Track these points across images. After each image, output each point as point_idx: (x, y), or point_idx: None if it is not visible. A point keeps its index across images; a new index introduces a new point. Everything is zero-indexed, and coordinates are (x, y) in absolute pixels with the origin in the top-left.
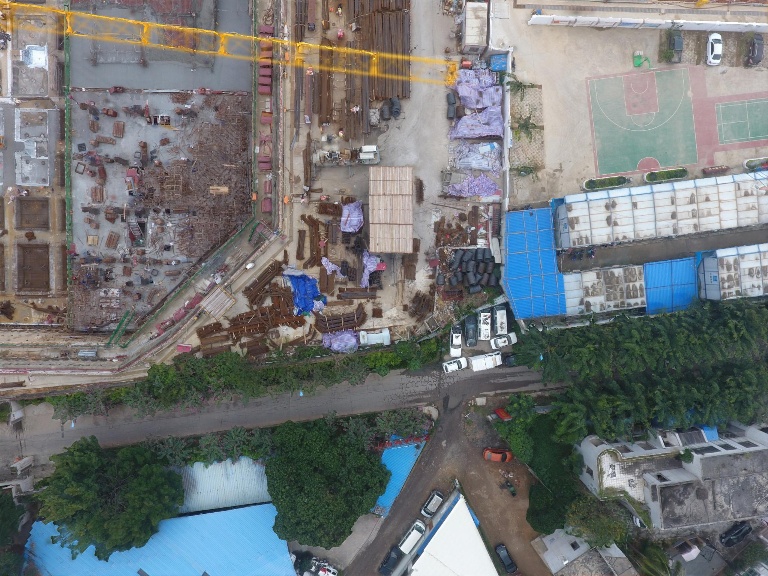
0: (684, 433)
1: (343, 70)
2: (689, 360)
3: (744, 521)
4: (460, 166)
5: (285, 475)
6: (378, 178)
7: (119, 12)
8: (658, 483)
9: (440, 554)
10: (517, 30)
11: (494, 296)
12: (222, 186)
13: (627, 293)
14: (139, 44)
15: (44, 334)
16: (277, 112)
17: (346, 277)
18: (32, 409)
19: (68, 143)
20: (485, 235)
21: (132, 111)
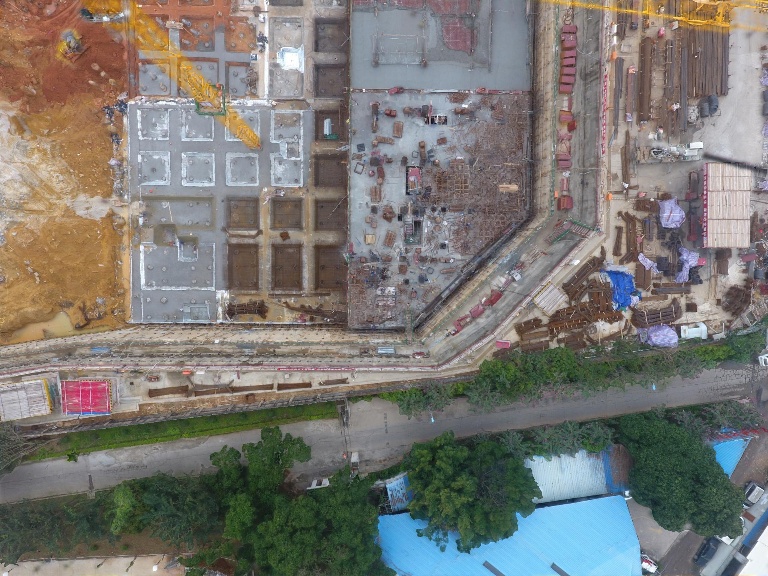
0: None
1: (662, 68)
2: None
3: None
4: None
5: (671, 467)
6: (717, 174)
7: (399, 14)
8: None
9: None
10: None
11: None
12: (511, 184)
13: None
14: (421, 45)
15: None
16: (596, 110)
17: (661, 272)
18: (357, 405)
19: (349, 143)
20: None
21: (416, 111)
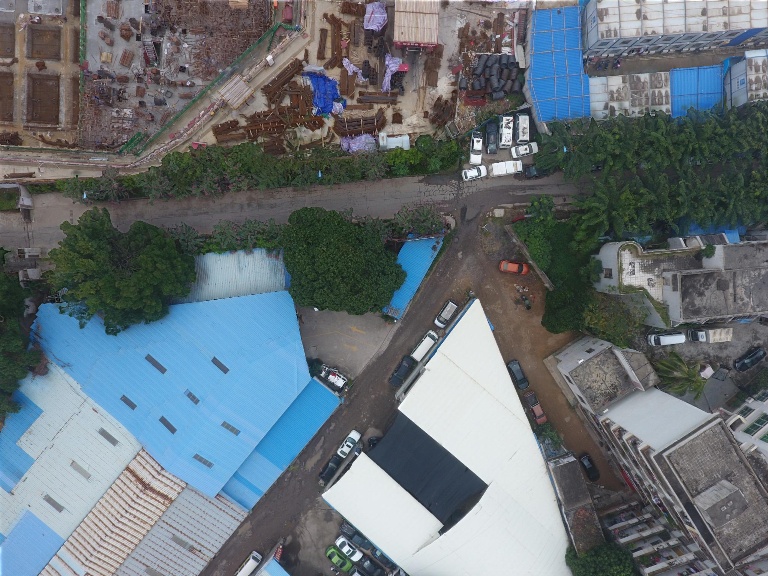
0: (705, 236)
1: None
2: (714, 154)
3: (758, 346)
4: None
5: (303, 237)
6: None
7: None
8: (679, 272)
9: (453, 355)
10: None
11: (517, 105)
12: None
13: (652, 99)
14: None
15: None
16: None
17: (367, 80)
18: (41, 200)
19: None
20: (510, 43)
21: None
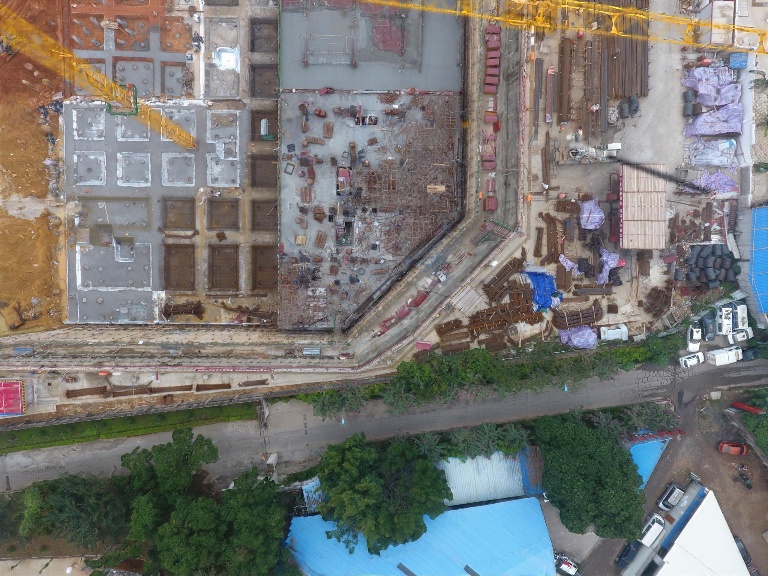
0: None
1: (582, 69)
2: None
3: None
4: (696, 163)
5: (575, 469)
6: (632, 175)
7: (329, 14)
8: None
9: (690, 546)
10: (756, 28)
11: (730, 291)
12: (439, 185)
13: None
14: (350, 45)
15: (249, 333)
16: (516, 111)
17: (582, 274)
18: (276, 407)
19: (279, 144)
20: (719, 231)
21: (345, 112)
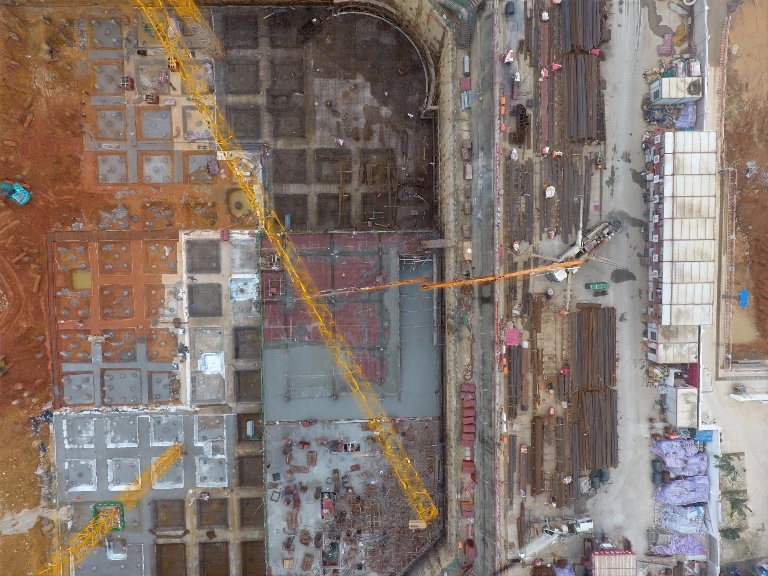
0: None
1: (554, 443)
2: None
3: None
4: (666, 526)
5: None
6: (603, 566)
7: (310, 349)
8: None
9: None
10: (720, 403)
11: None
12: (420, 522)
13: None
14: (331, 381)
15: None
16: (491, 484)
17: None
18: None
19: (264, 475)
20: None
21: (327, 446)
